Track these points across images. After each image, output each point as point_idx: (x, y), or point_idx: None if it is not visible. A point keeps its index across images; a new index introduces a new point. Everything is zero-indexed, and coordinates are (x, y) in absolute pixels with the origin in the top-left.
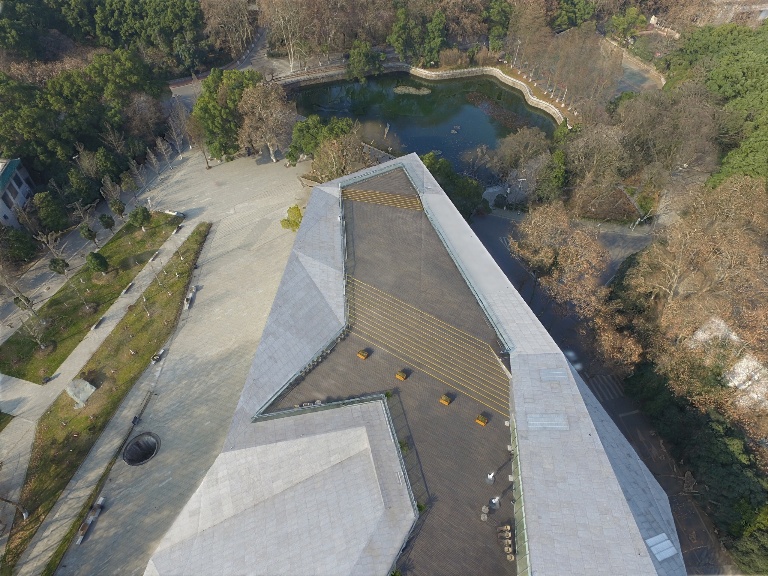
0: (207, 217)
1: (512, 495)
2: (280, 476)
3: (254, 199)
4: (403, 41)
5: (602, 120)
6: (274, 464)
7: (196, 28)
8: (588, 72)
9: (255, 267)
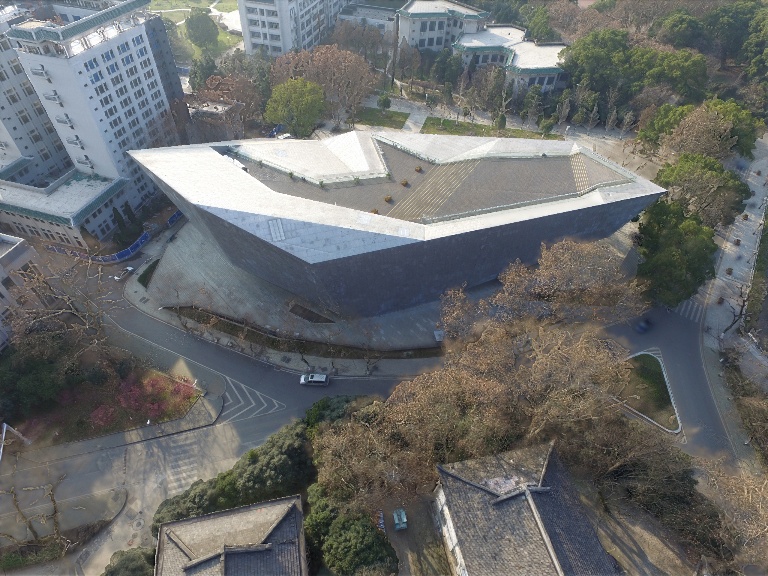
0: None
1: None
2: None
3: None
4: None
5: None
6: None
7: None
8: None
9: None
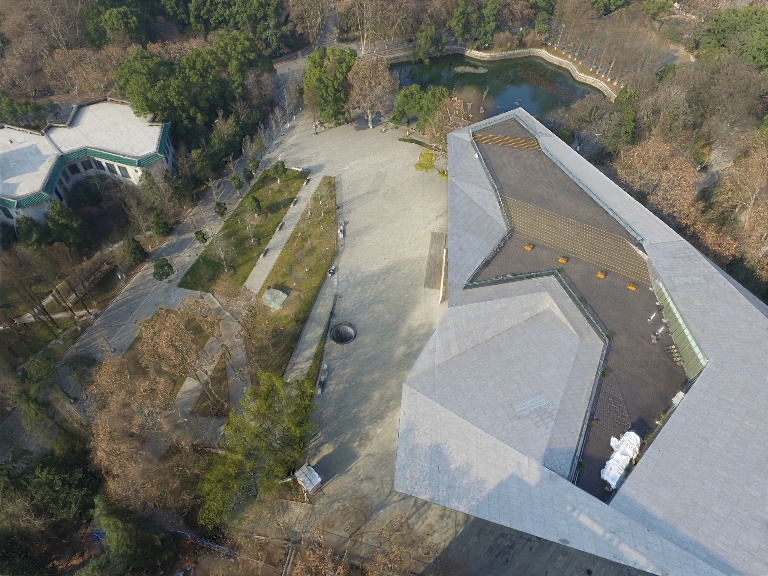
0: (328, 172)
1: (668, 330)
2: (489, 326)
3: (364, 157)
4: (462, 25)
5: (653, 88)
6: (485, 317)
7: (277, 16)
8: (635, 48)
9: (386, 207)
